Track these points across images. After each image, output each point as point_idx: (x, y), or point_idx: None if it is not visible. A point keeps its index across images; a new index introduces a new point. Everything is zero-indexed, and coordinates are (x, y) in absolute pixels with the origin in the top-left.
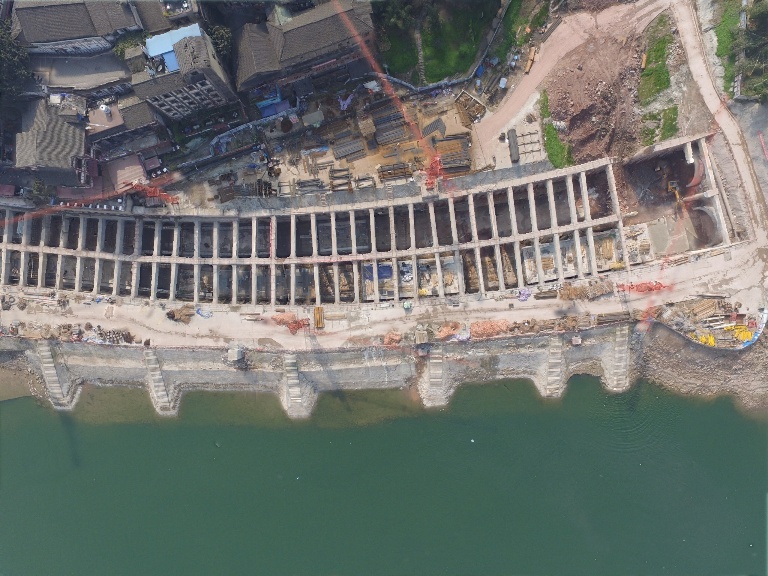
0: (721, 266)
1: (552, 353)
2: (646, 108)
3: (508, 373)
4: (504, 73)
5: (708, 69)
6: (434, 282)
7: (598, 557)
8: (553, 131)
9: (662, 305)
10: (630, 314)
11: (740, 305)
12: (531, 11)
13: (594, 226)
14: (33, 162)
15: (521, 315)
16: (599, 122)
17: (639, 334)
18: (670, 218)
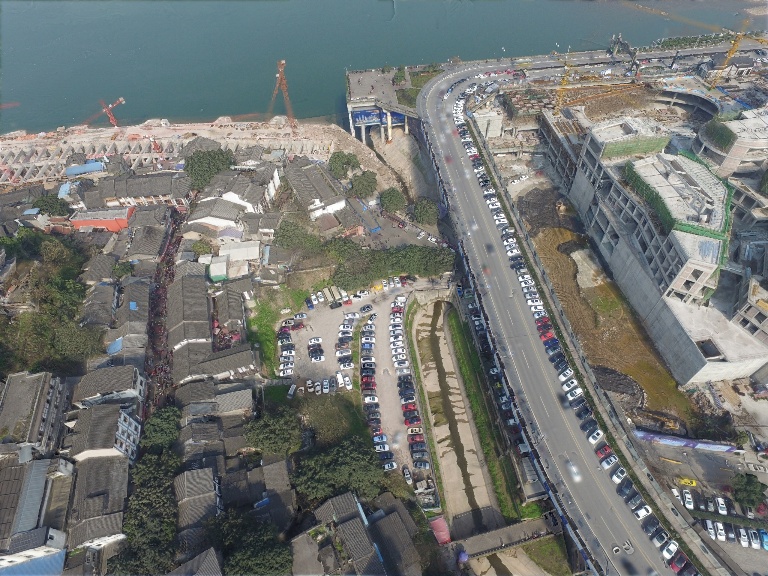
0: None
1: (4, 135)
2: None
3: None
4: None
5: None
6: None
7: (39, 91)
8: None
9: None
10: None
11: None
12: None
13: None
14: (202, 138)
15: (7, 143)
16: None
17: None
18: None
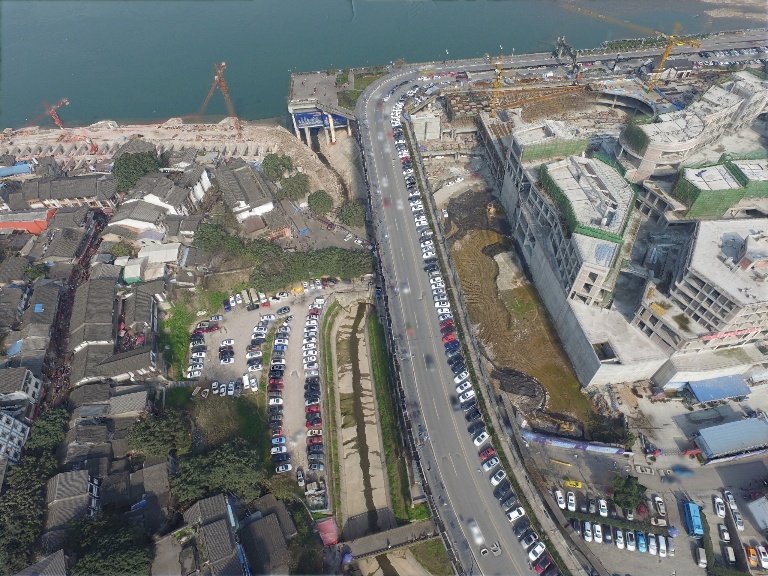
0: None
1: None
2: None
3: None
4: None
5: None
6: None
7: None
8: None
9: None
10: None
11: None
12: None
13: None
14: (136, 140)
15: None
16: None
17: None
18: None
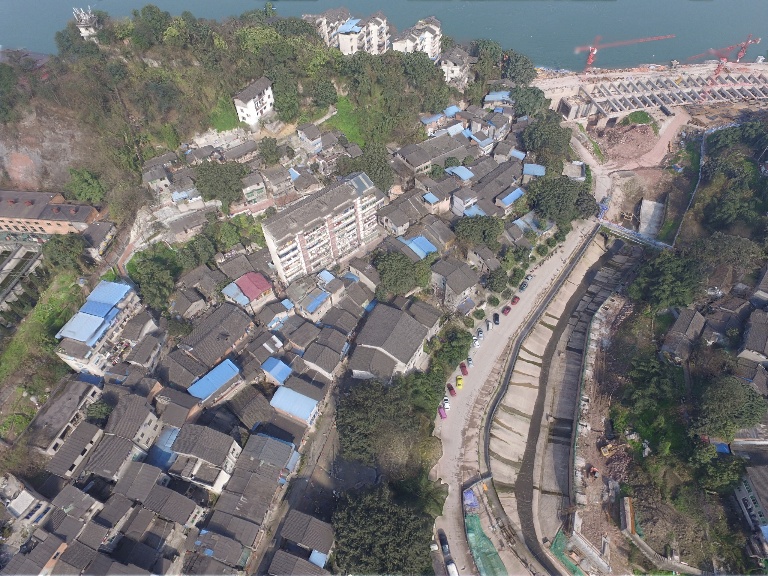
0: None
1: None
2: None
3: None
4: None
5: None
6: None
7: (552, 37)
8: None
9: None
10: None
11: None
12: (683, 161)
13: (591, 116)
14: None
15: None
16: None
17: None
18: None
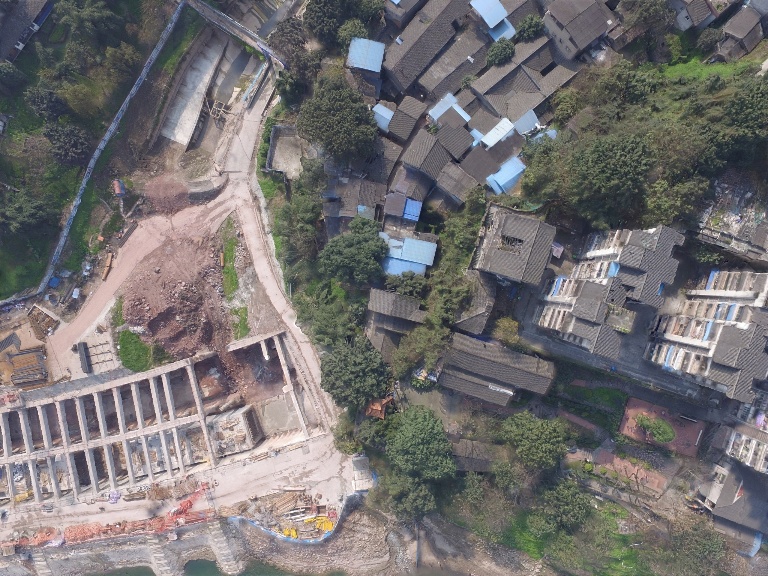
0: (300, 459)
1: (152, 549)
2: (231, 303)
3: (124, 564)
4: (80, 282)
5: (273, 270)
6: (43, 481)
7: None
8: (131, 336)
9: (247, 500)
10: (216, 511)
11: (320, 496)
12: (101, 220)
13: None
14: None
15: (112, 517)
16: (184, 320)
17: (234, 525)
18: (288, 394)
